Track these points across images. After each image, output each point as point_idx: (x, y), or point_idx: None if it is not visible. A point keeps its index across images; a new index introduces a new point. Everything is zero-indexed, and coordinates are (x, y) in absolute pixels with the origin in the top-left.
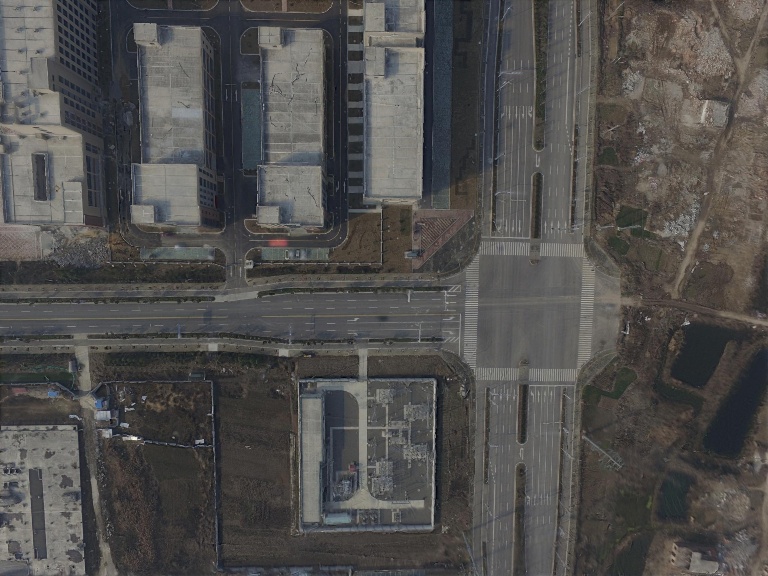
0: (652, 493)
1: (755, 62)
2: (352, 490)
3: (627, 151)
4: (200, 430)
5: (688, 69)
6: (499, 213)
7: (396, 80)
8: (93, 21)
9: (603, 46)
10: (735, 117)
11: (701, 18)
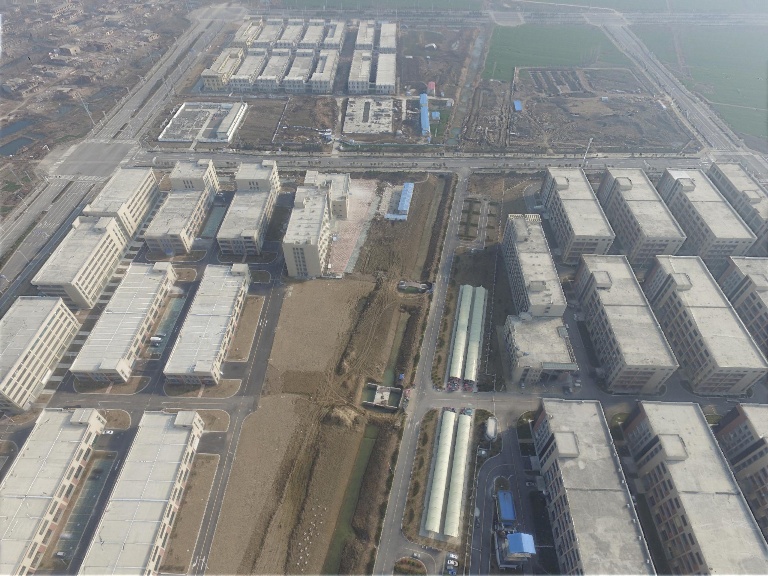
0: None
1: None
2: None
3: None
4: None
5: None
6: None
7: None
8: None
9: None
10: None
11: None
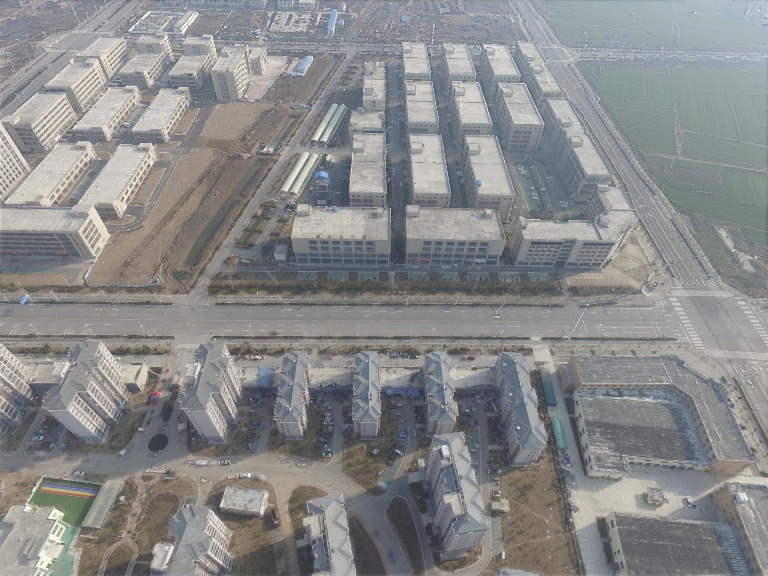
0: None
1: None
2: None
3: (8, 67)
4: None
5: None
6: None
7: None
8: None
9: None
10: None
11: None
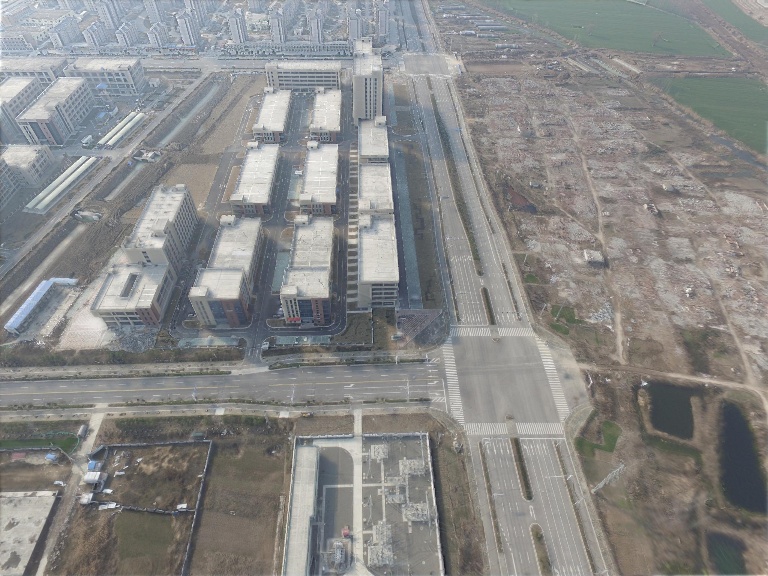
0: (703, 565)
1: (606, 235)
2: (345, 562)
3: (543, 276)
4: (186, 493)
5: (565, 238)
6: (461, 310)
7: (378, 229)
8: (194, 226)
9: (508, 231)
10: (609, 258)
11: (562, 218)
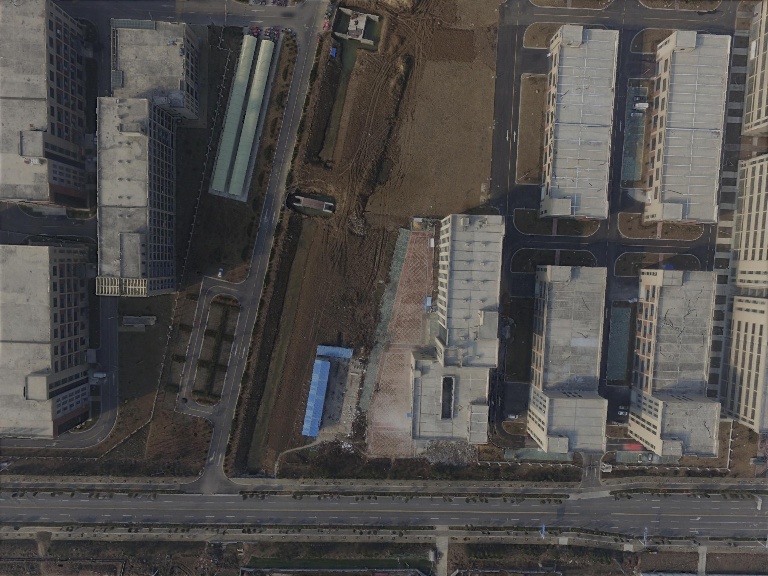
0: None
1: None
2: None
3: None
4: None
5: None
6: None
7: None
8: None
9: None
10: None
11: None
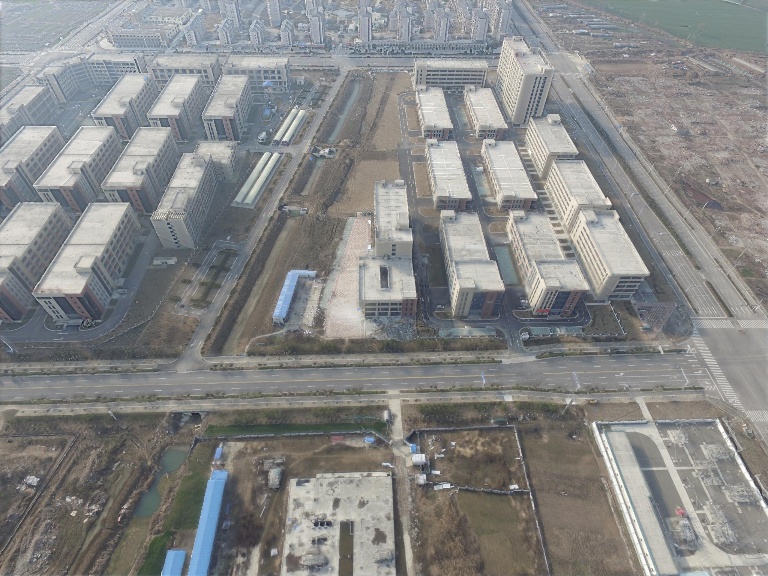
0: None
1: None
2: None
3: (757, 270)
4: (512, 475)
5: (763, 234)
6: (694, 303)
7: (603, 224)
8: None
9: (704, 226)
10: None
11: (752, 214)
